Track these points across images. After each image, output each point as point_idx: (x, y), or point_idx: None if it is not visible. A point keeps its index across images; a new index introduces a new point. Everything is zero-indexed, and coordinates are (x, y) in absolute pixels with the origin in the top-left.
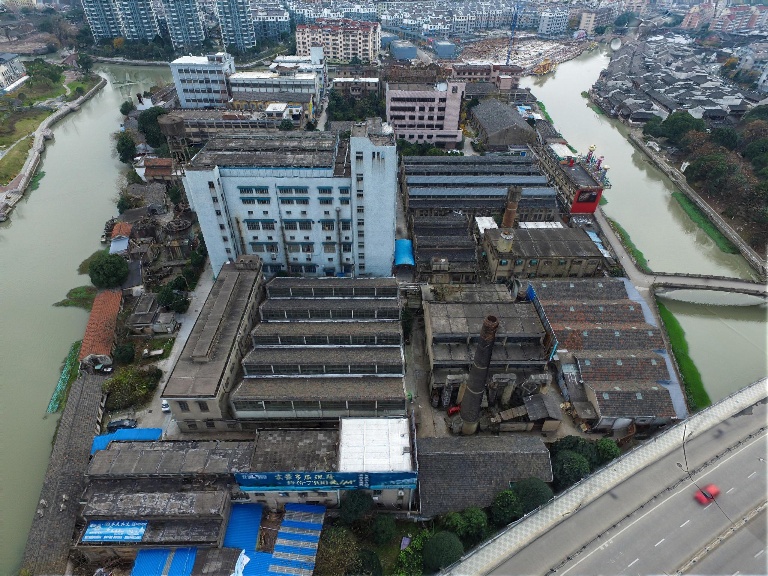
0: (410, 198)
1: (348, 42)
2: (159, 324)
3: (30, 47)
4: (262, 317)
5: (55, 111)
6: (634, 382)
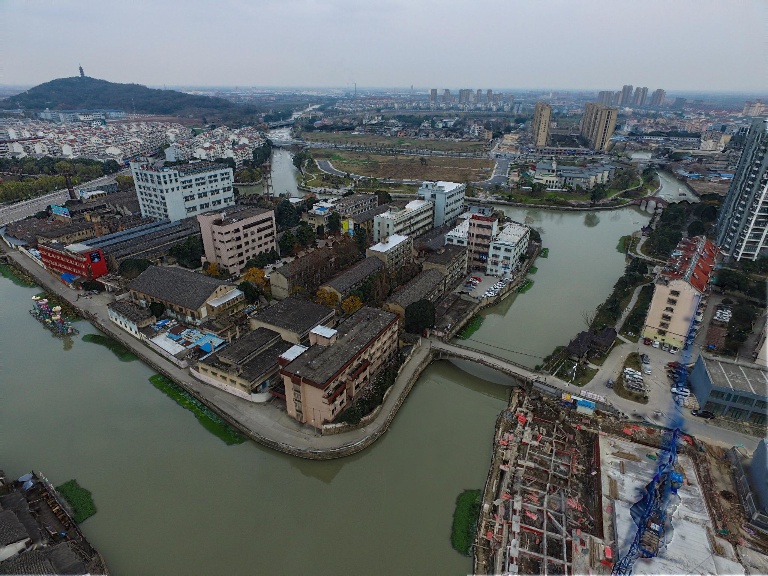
0: None
1: None
2: None
3: None
4: None
5: None
6: None
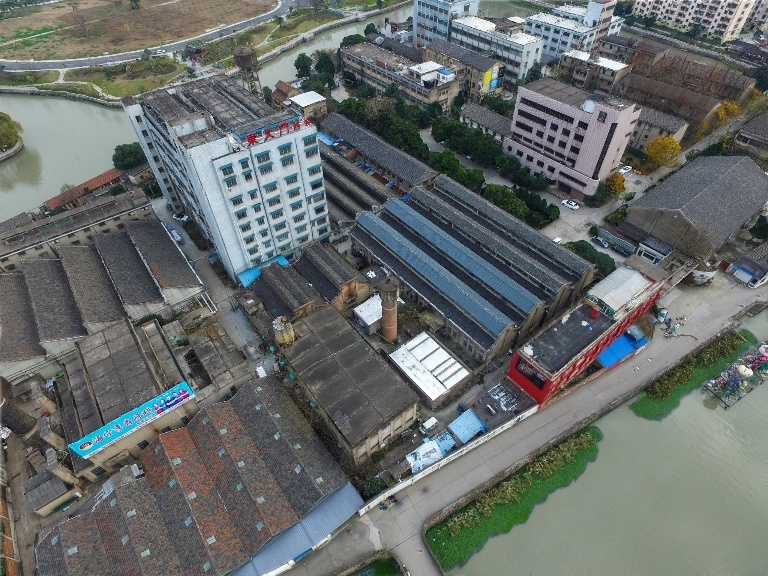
0: (359, 224)
1: (706, 2)
2: None
3: None
4: None
5: (342, 18)
6: (102, 571)
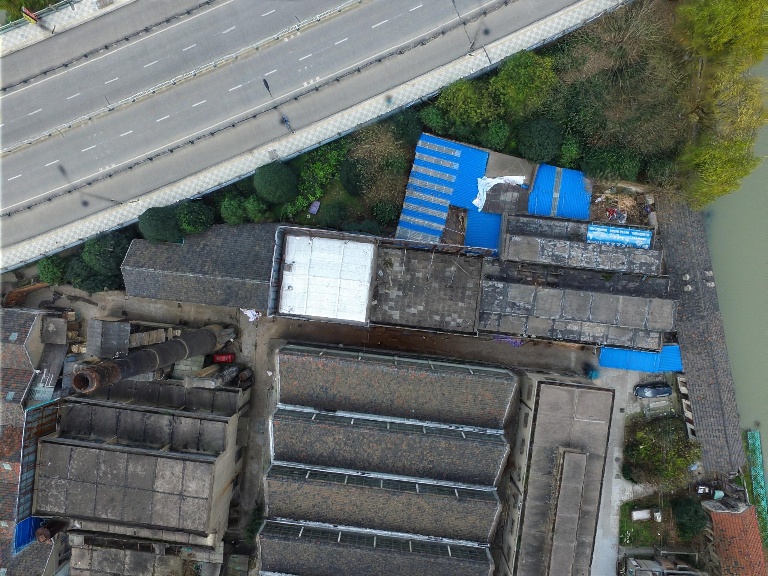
0: None
1: None
2: (653, 572)
3: None
4: (488, 552)
5: None
6: None
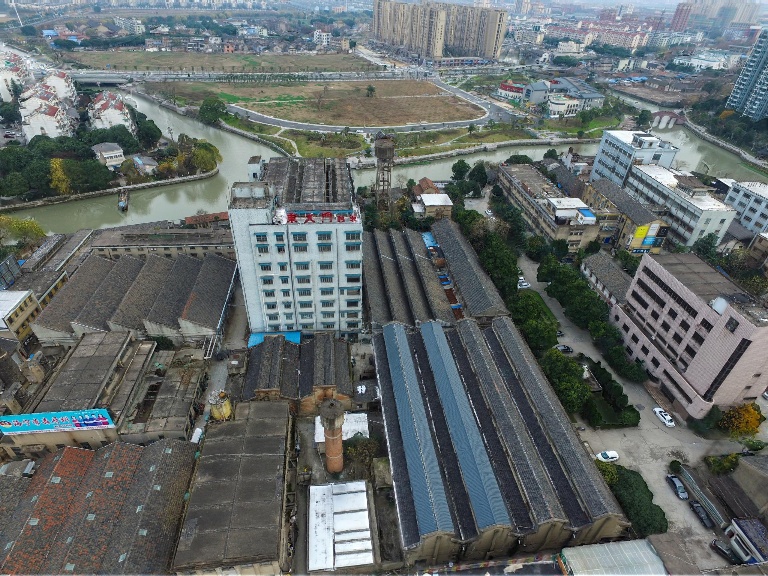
0: None
1: None
2: None
3: (670, 99)
4: None
5: (534, 139)
6: None
